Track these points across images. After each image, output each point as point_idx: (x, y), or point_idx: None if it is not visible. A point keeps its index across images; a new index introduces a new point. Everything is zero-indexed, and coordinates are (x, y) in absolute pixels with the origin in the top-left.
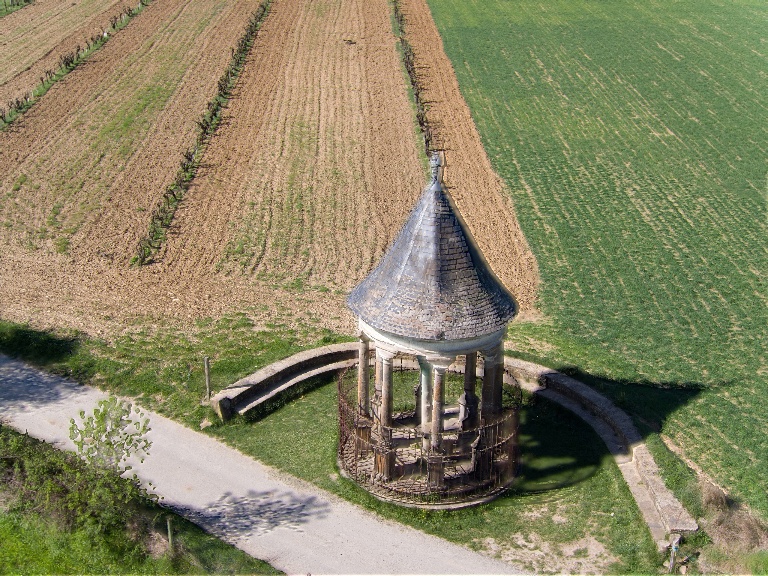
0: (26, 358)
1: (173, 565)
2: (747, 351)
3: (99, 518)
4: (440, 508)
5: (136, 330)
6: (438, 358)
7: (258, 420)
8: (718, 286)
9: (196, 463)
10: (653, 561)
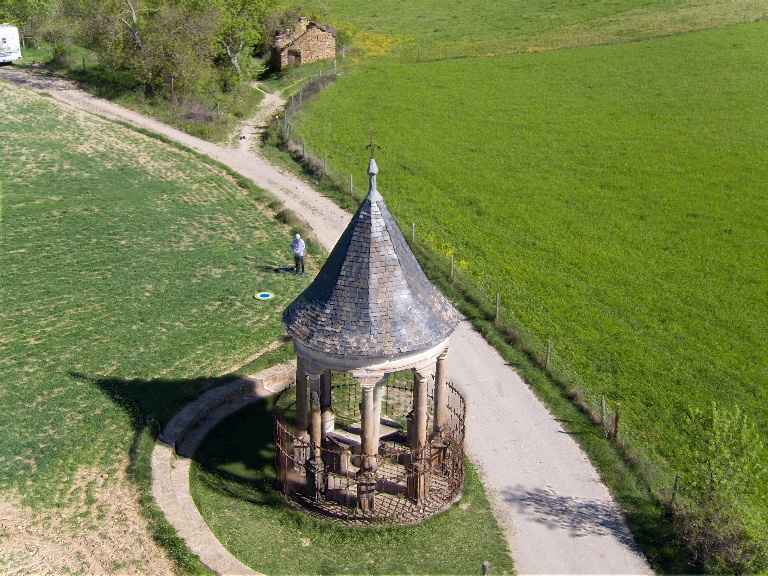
0: None
1: None
2: None
3: None
4: None
5: None
6: None
7: None
8: None
9: (569, 575)
10: None
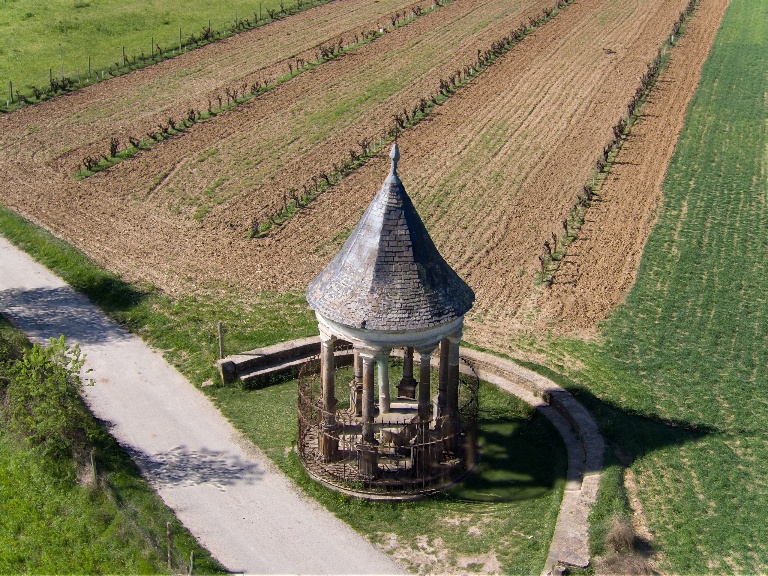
0: (102, 303)
1: (92, 495)
2: None
3: (45, 442)
4: (360, 496)
5: (206, 293)
6: (363, 346)
7: (259, 388)
8: None
9: (176, 415)
10: None
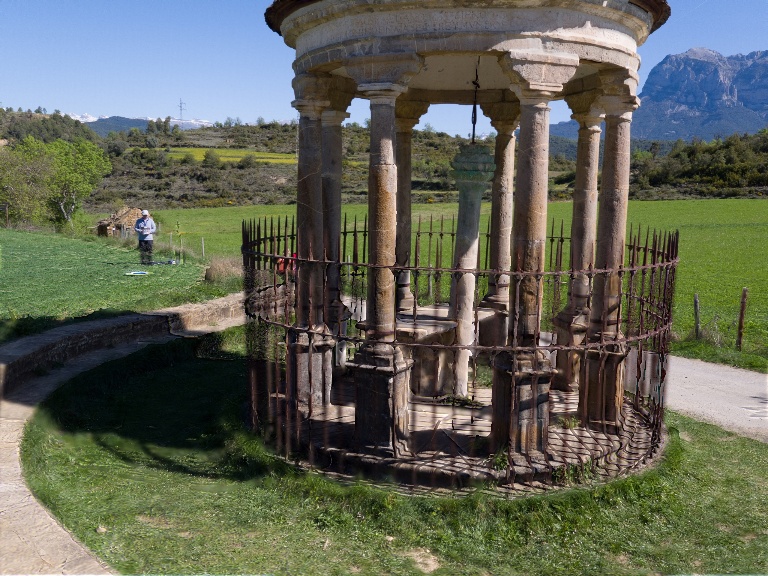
0: None
1: None
2: None
3: None
4: None
5: None
6: None
7: None
8: None
9: None
10: None
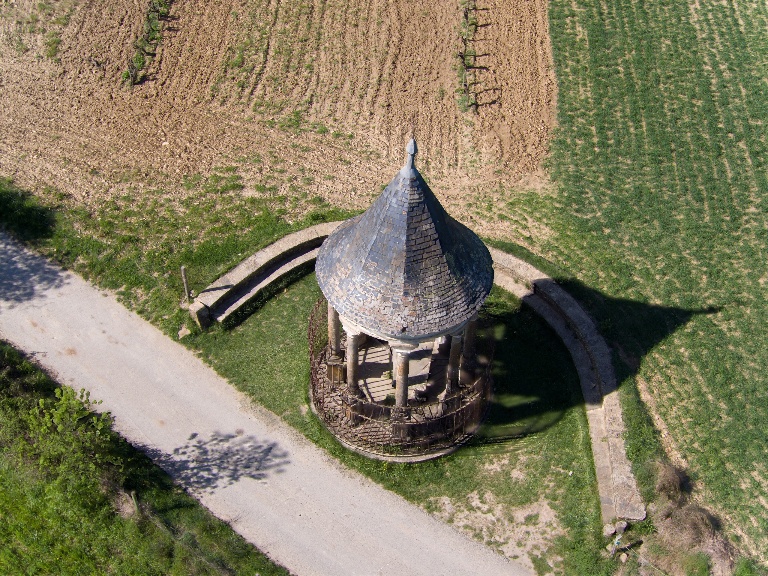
0: (11, 229)
1: (140, 527)
2: (756, 247)
3: (69, 481)
4: (401, 461)
5: (122, 191)
6: (400, 344)
7: (237, 324)
8: (748, 140)
9: (171, 386)
10: (597, 543)
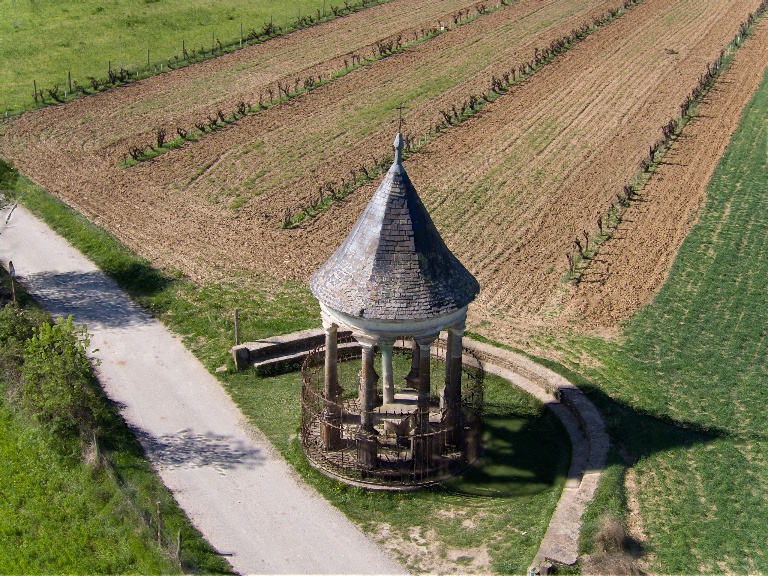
0: (129, 288)
1: (94, 473)
2: None
3: (52, 419)
4: (357, 485)
5: (231, 281)
6: (362, 335)
7: (272, 375)
8: None
9: (187, 398)
10: None
